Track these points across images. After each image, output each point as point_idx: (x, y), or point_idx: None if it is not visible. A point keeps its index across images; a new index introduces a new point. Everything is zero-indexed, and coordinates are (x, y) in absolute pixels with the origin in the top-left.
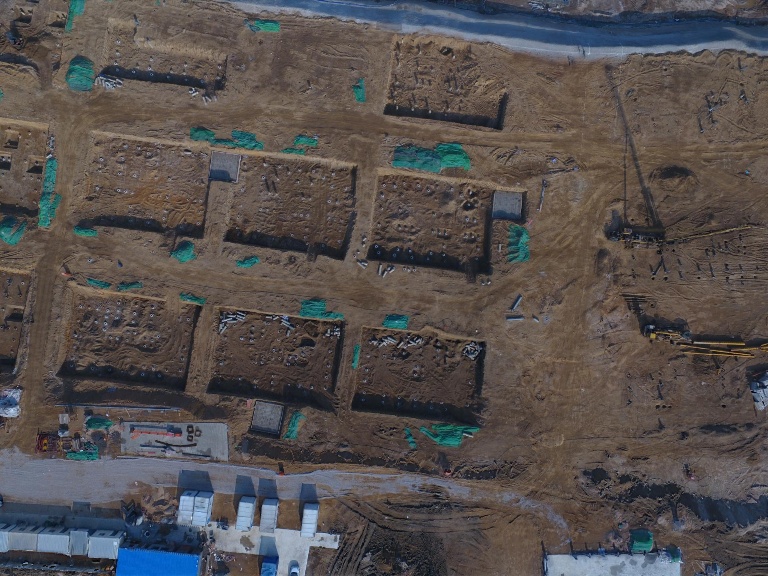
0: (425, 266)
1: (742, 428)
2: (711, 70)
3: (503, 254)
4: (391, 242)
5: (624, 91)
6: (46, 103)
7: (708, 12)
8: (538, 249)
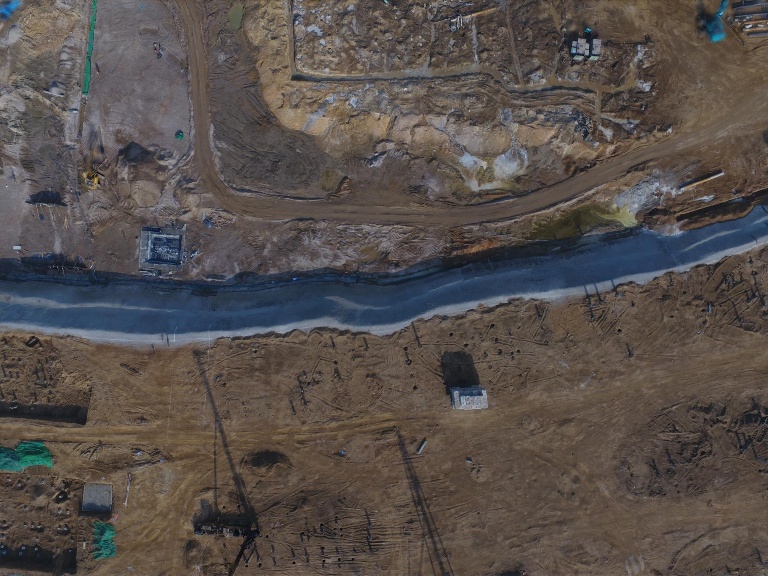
0: (12, 565)
1: None
2: (303, 349)
3: (89, 551)
4: None
5: (213, 376)
6: None
7: (325, 270)
8: (125, 544)
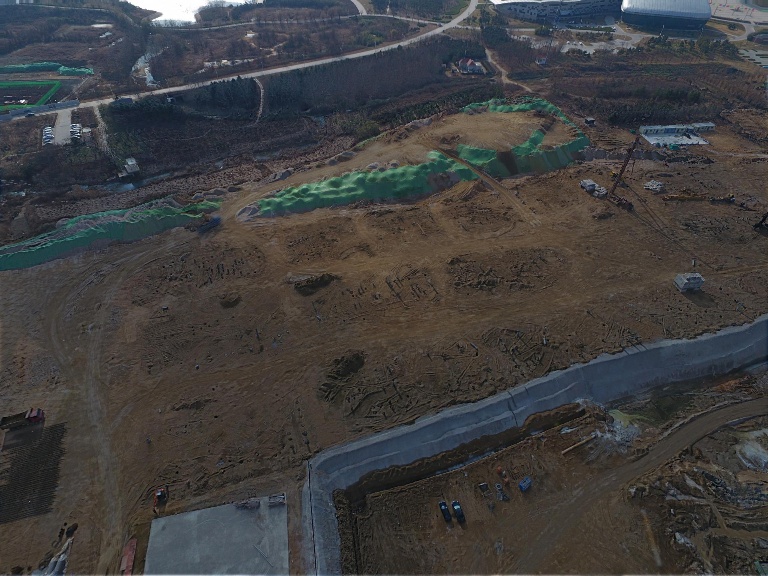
0: None
1: (655, 176)
2: None
3: None
4: None
5: None
6: None
7: None
8: None
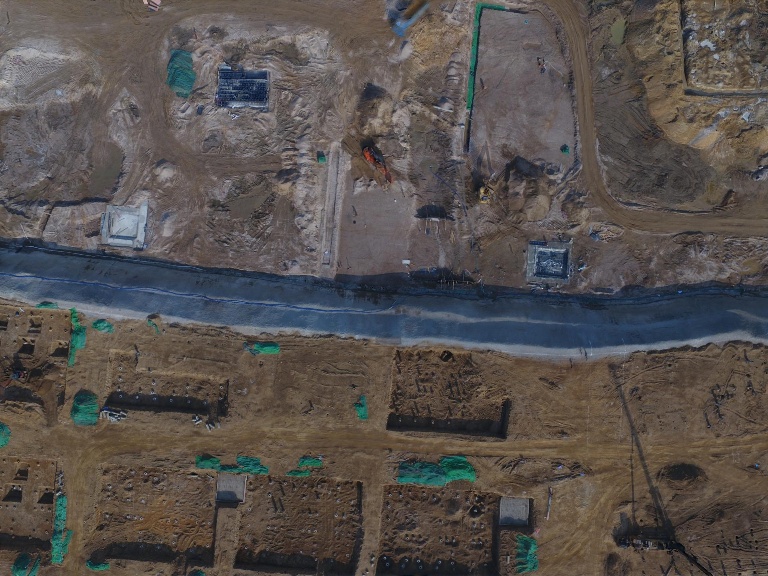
0: None
1: None
2: (716, 362)
3: (512, 565)
4: (399, 555)
5: (628, 390)
6: (53, 439)
7: (711, 283)
8: (547, 558)
